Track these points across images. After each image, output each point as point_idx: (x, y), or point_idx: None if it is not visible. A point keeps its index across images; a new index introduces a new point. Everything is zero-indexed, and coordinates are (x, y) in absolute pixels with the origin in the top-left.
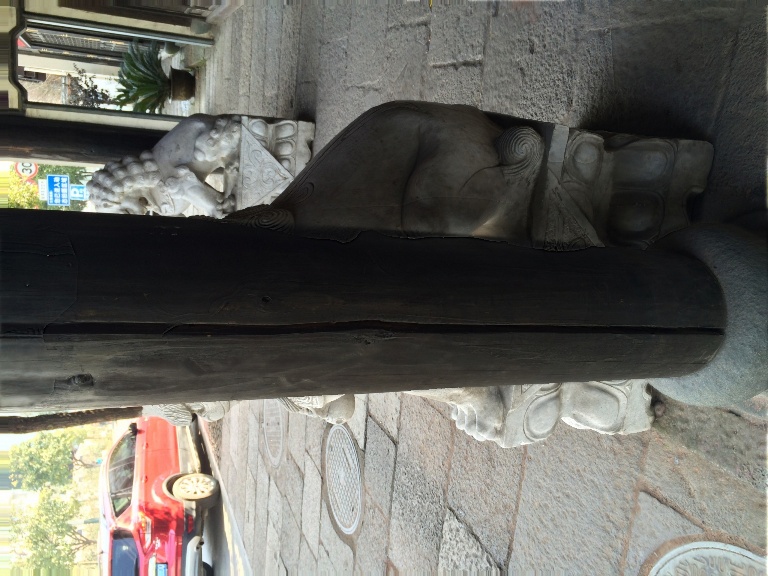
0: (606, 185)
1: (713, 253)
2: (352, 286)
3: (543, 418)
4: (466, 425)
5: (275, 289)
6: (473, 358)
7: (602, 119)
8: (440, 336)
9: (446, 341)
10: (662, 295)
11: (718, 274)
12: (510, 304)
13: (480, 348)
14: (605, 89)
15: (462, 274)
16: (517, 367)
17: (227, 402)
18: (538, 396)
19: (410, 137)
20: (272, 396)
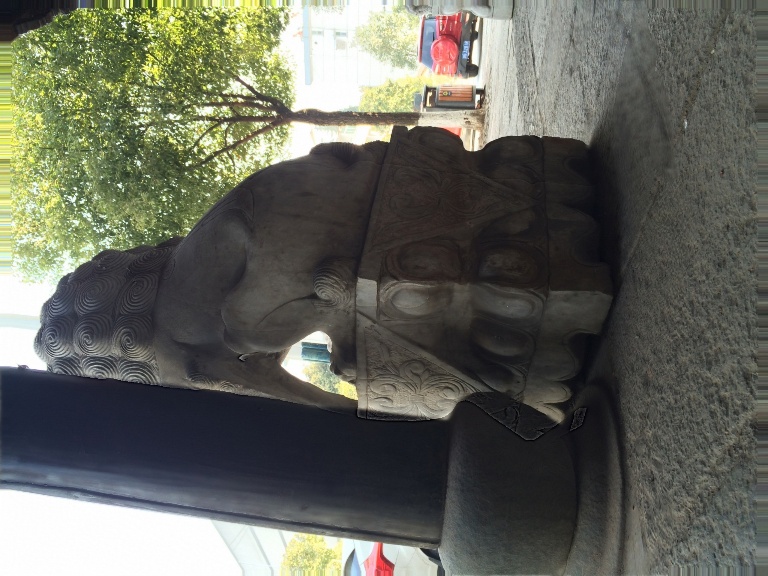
0: (464, 310)
1: (452, 472)
2: (56, 466)
3: None
4: None
5: (1, 462)
6: None
7: (599, 151)
8: (132, 502)
9: (138, 505)
10: (357, 507)
11: (447, 494)
12: (189, 494)
13: None
14: (608, 115)
15: (151, 465)
16: None
17: None
18: None
19: (238, 250)
20: None
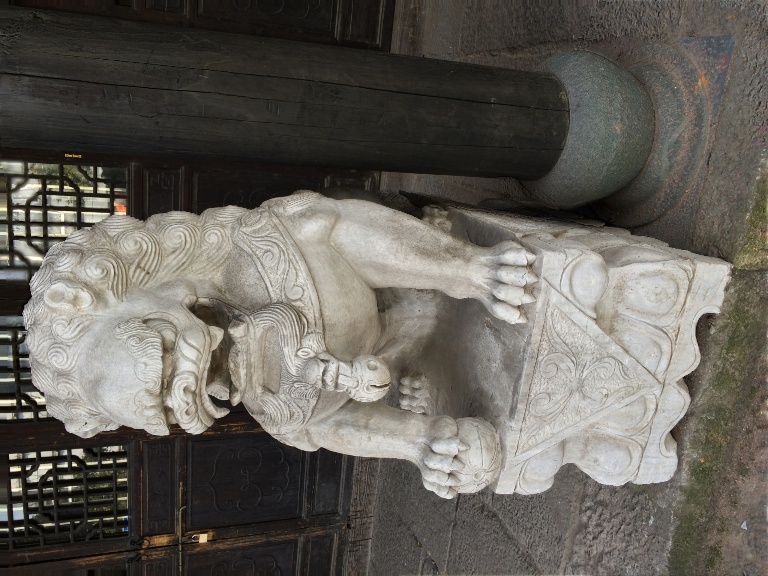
0: None
1: None
2: None
3: None
4: (495, 271)
5: None
6: None
7: None
8: None
9: None
10: None
11: None
12: None
13: (335, 45)
14: None
15: None
16: (379, 57)
17: (204, 325)
18: None
19: None
20: (186, 58)
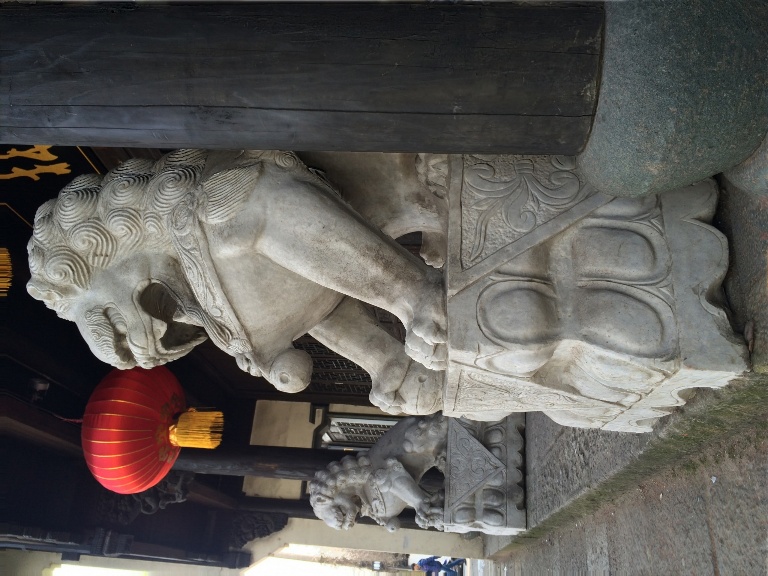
0: None
1: None
2: None
3: (508, 310)
4: None
5: None
6: (228, 31)
7: None
8: (188, 8)
9: (193, 11)
10: None
11: None
12: None
13: (232, 18)
14: None
15: None
16: (288, 47)
17: (149, 320)
18: (496, 282)
19: None
20: (46, 93)
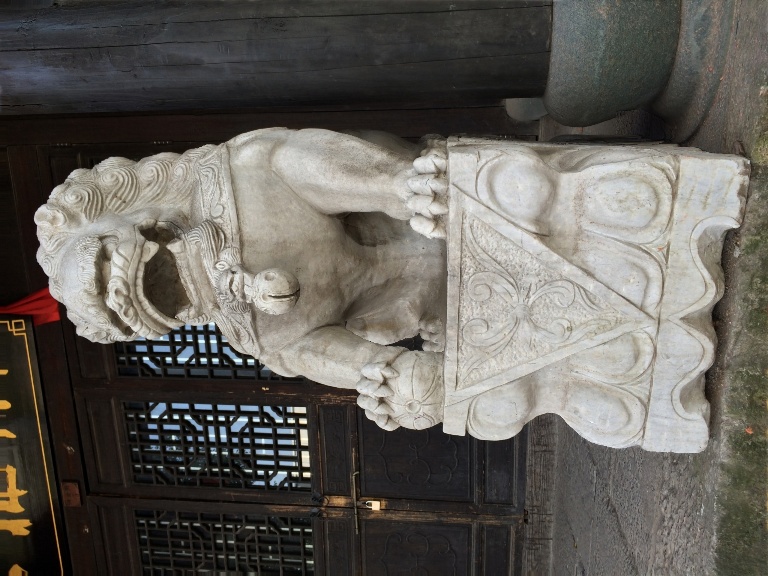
0: None
1: None
2: None
3: None
4: None
5: None
6: None
7: None
8: None
9: None
10: None
11: None
12: None
13: None
14: None
15: None
16: None
17: (143, 240)
18: None
19: None
20: (152, 16)
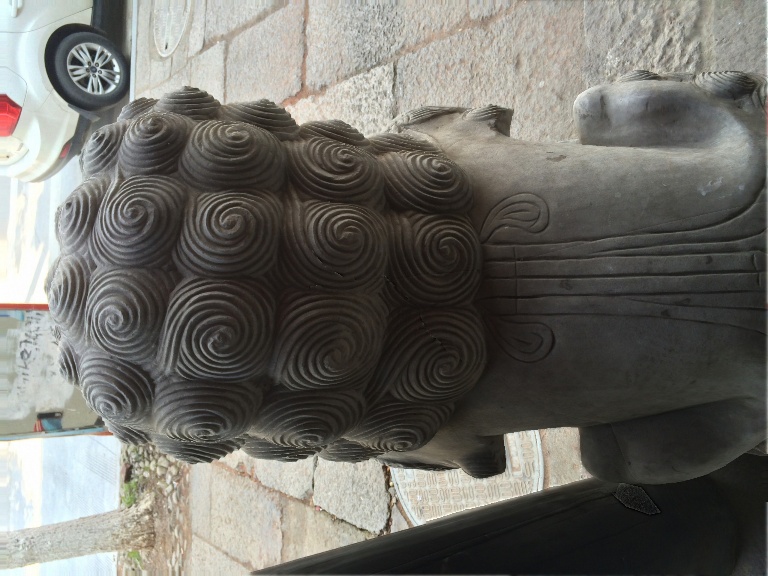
0: None
1: (749, 575)
2: None
3: None
4: None
5: None
6: None
7: None
8: None
9: None
10: None
11: None
12: None
13: None
14: None
15: None
16: None
17: None
18: None
19: (727, 395)
20: None
